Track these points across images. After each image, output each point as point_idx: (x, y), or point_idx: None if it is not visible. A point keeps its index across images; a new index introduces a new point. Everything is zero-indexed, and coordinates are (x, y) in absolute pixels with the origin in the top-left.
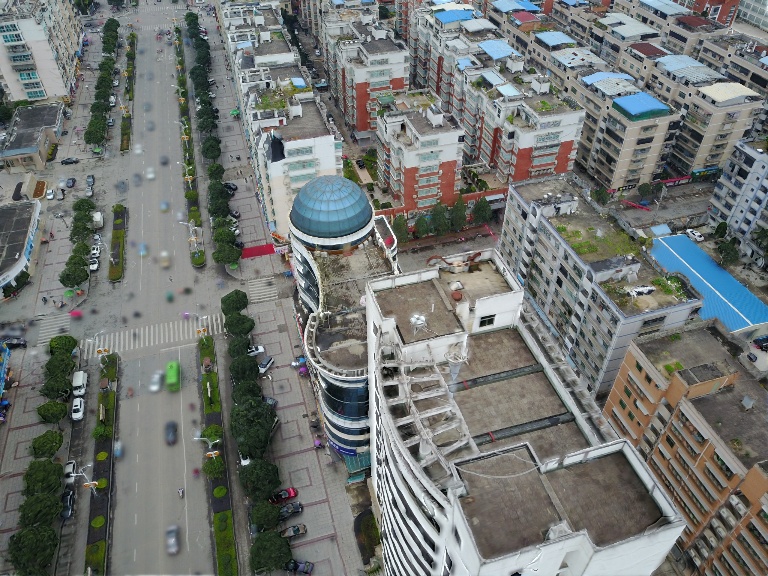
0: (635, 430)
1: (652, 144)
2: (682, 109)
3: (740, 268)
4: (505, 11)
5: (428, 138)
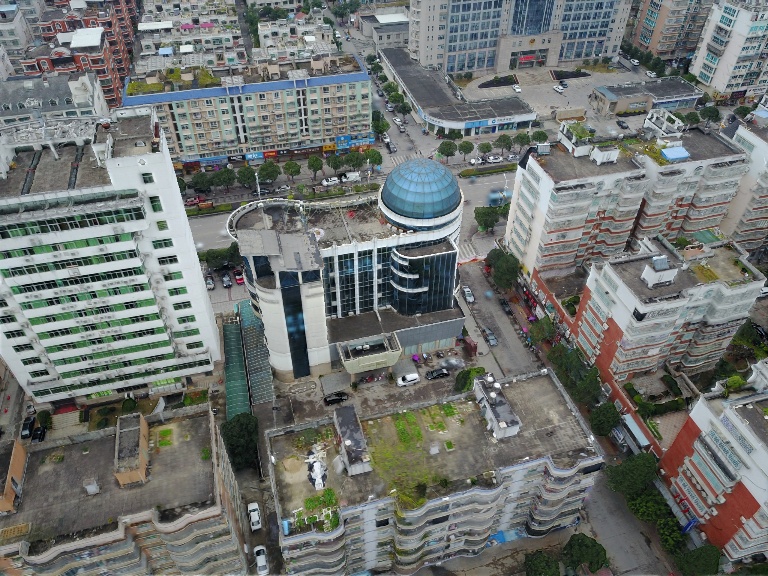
0: None
1: None
2: None
3: None
4: None
5: (611, 273)
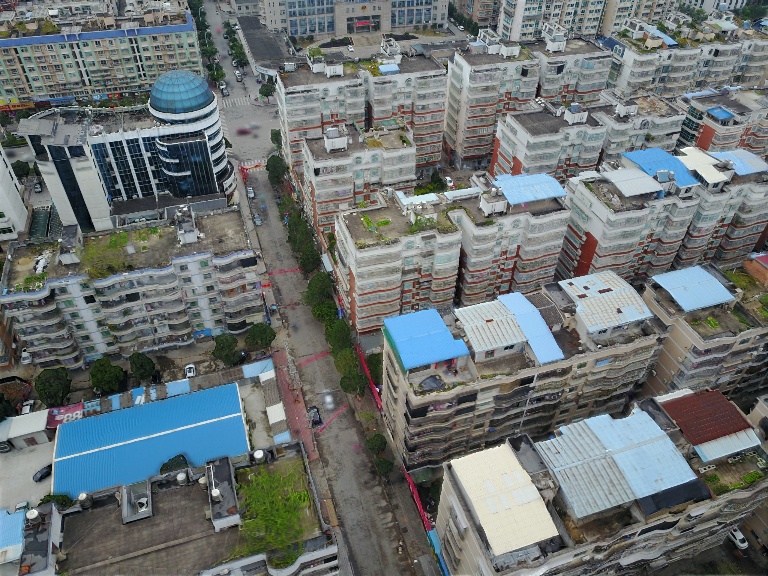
0: None
1: None
2: None
3: None
4: None
5: None
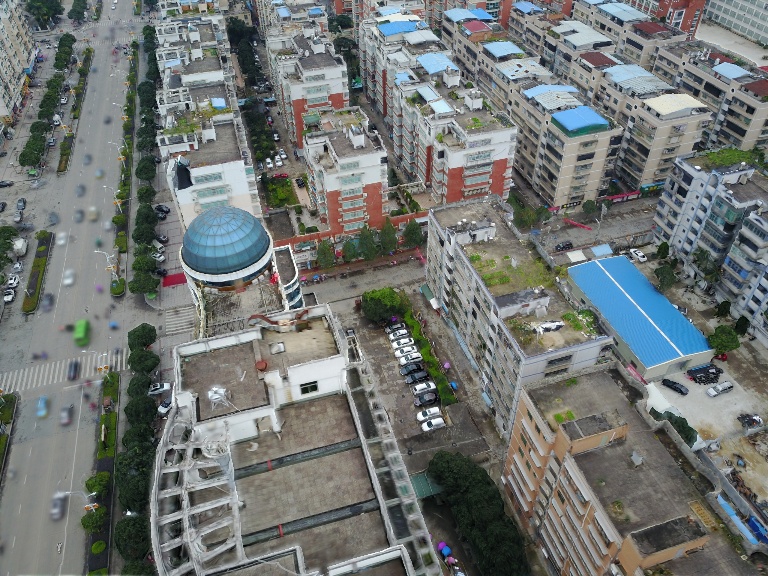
0: (533, 481)
1: (594, 160)
2: (629, 122)
3: (682, 291)
4: (456, 21)
5: (347, 160)
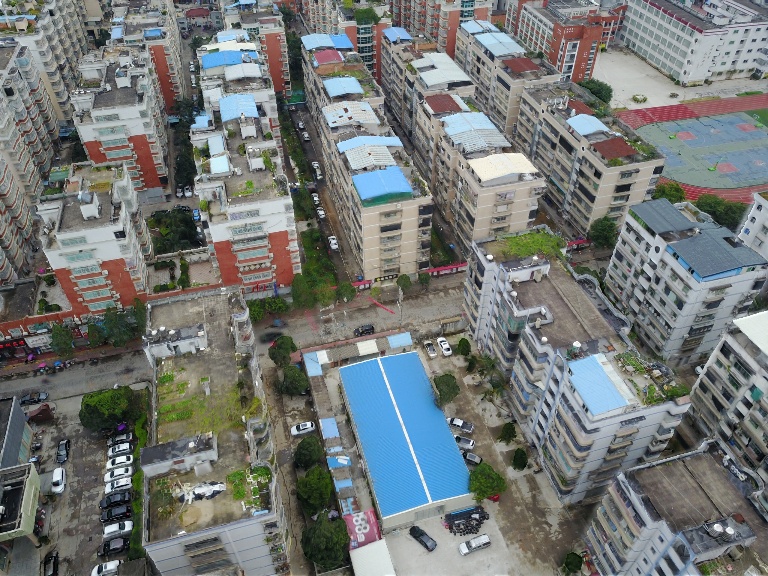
0: None
1: (403, 230)
2: (459, 182)
3: (479, 398)
4: (308, 49)
5: (68, 236)
